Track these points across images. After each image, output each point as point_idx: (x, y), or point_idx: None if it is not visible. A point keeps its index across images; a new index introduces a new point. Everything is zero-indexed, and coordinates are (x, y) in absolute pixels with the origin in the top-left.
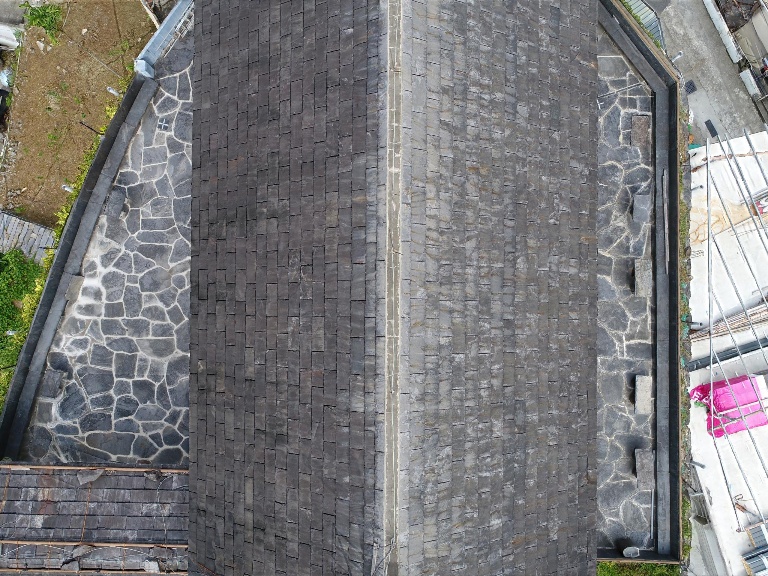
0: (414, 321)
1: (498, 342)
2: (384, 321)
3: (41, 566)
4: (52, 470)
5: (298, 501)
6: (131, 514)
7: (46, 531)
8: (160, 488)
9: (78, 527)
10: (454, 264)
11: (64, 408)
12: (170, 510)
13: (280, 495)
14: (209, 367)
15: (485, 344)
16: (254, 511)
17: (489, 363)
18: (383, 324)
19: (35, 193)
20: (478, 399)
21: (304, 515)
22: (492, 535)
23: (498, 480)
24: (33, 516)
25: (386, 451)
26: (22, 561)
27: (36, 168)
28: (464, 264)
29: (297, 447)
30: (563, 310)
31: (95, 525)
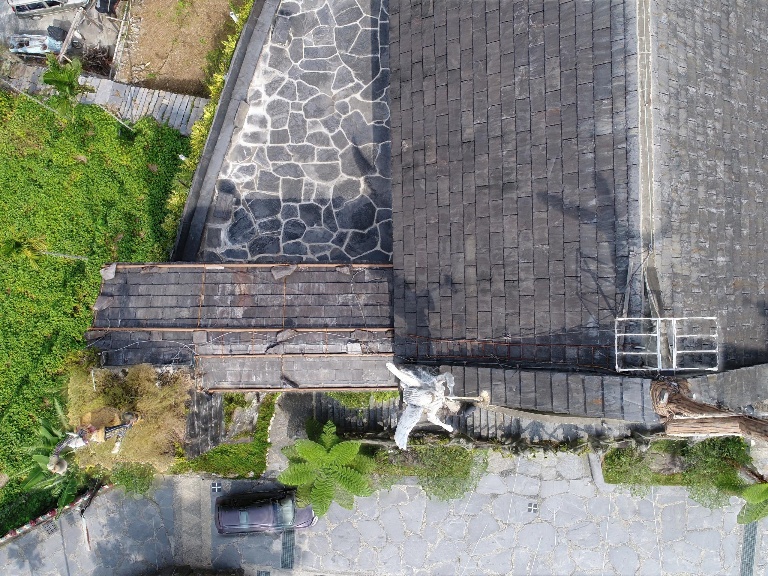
0: (660, 43)
1: (718, 87)
2: (635, 39)
3: (245, 352)
4: (246, 268)
5: (532, 240)
6: (328, 304)
7: (247, 320)
8: (353, 281)
9: (278, 316)
10: (686, 0)
11: (233, 233)
12: (365, 300)
13: (510, 240)
14: (416, 143)
15: (709, 86)
16: (478, 264)
17: (713, 105)
18: (634, 42)
19: (159, 67)
20: (706, 136)
21: (540, 251)
22: (718, 271)
23: (722, 219)
24: (233, 308)
25: (641, 162)
26: (227, 347)
27: (159, 43)
28: (693, 3)
29: (529, 189)
30: (763, 75)
31: (294, 314)
